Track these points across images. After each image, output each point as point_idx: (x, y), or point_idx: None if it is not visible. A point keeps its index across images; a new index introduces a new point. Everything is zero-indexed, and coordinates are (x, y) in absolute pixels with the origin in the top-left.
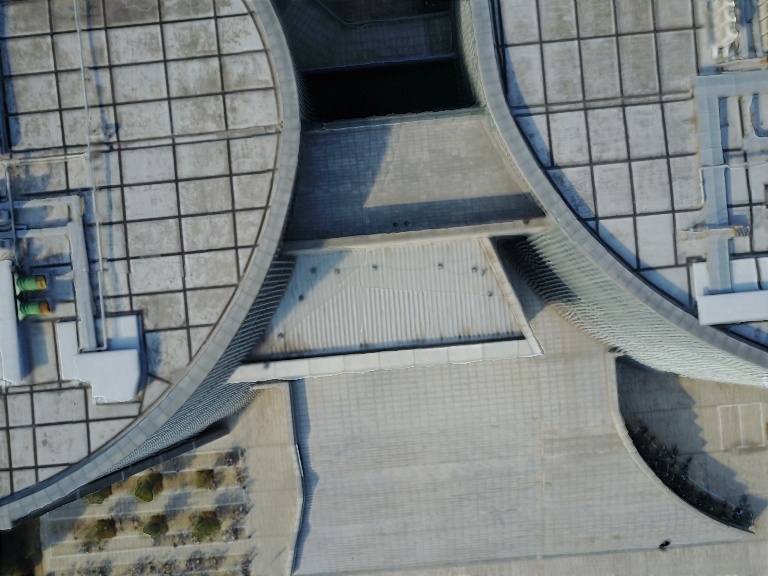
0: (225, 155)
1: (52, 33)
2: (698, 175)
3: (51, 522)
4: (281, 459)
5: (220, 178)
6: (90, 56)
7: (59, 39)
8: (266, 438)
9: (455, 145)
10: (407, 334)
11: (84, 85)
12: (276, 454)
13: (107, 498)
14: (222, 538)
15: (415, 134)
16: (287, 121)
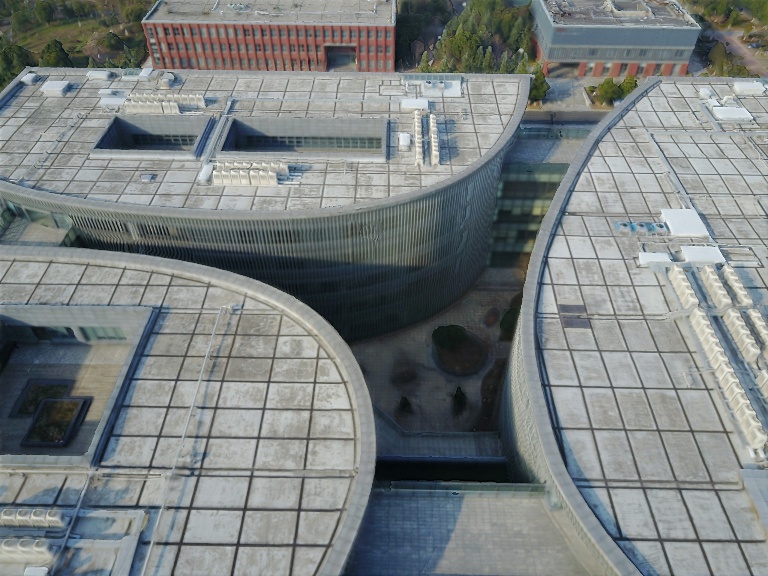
0: (298, 491)
1: (177, 380)
2: None
3: None
4: None
5: (288, 512)
6: (202, 399)
7: (181, 384)
8: None
9: (516, 520)
10: None
11: (189, 419)
12: None
13: None
14: None
15: (477, 506)
16: (363, 465)
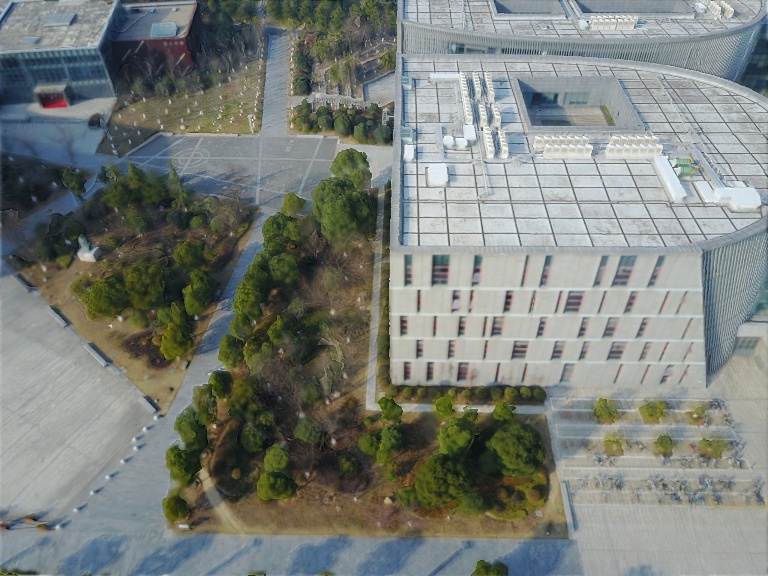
0: (764, 138)
1: None
2: None
3: (561, 439)
4: (758, 410)
5: (766, 144)
6: (679, 110)
7: (662, 105)
8: (739, 394)
9: None
10: None
11: (680, 116)
12: (752, 406)
13: (610, 425)
14: (728, 462)
15: None
16: None
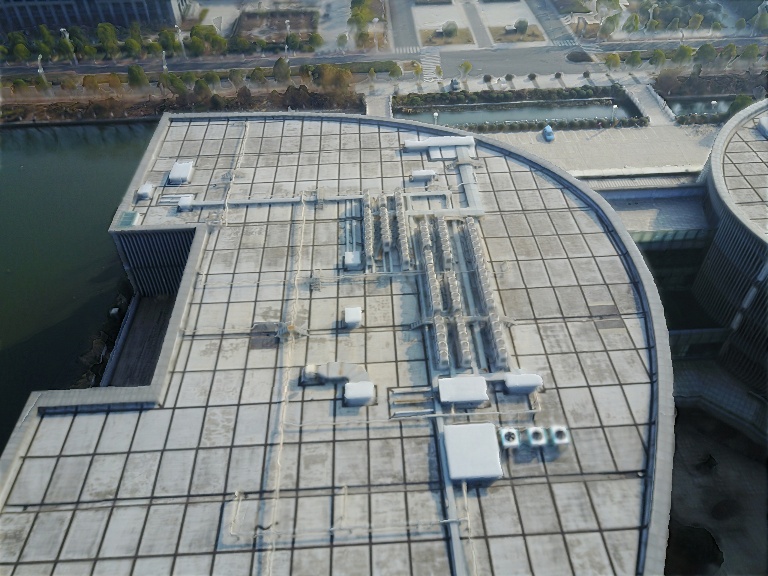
0: (761, 195)
1: None
2: None
3: None
4: None
5: (759, 187)
6: None
7: None
8: None
9: None
10: (609, 183)
11: None
12: None
13: None
14: None
15: None
16: (731, 200)
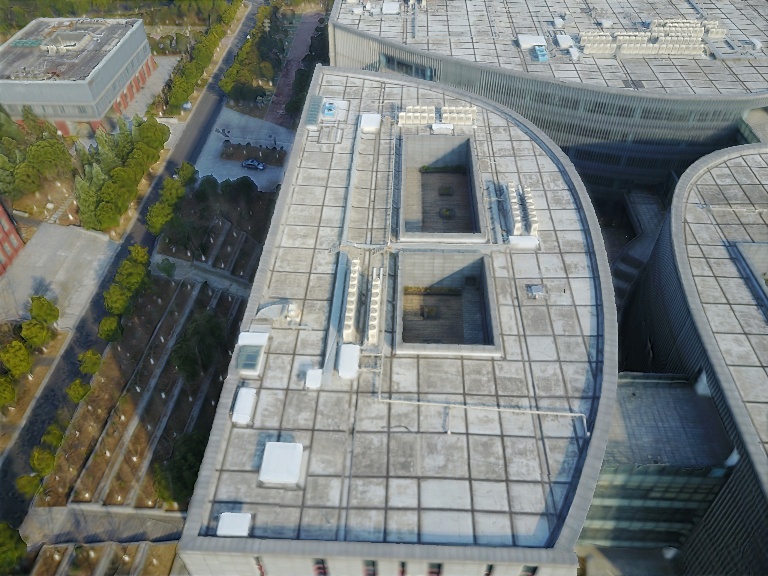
0: None
1: None
2: (760, 59)
3: None
4: None
5: None
6: None
7: None
8: None
9: None
10: None
11: None
12: None
13: None
14: None
15: None
16: None
